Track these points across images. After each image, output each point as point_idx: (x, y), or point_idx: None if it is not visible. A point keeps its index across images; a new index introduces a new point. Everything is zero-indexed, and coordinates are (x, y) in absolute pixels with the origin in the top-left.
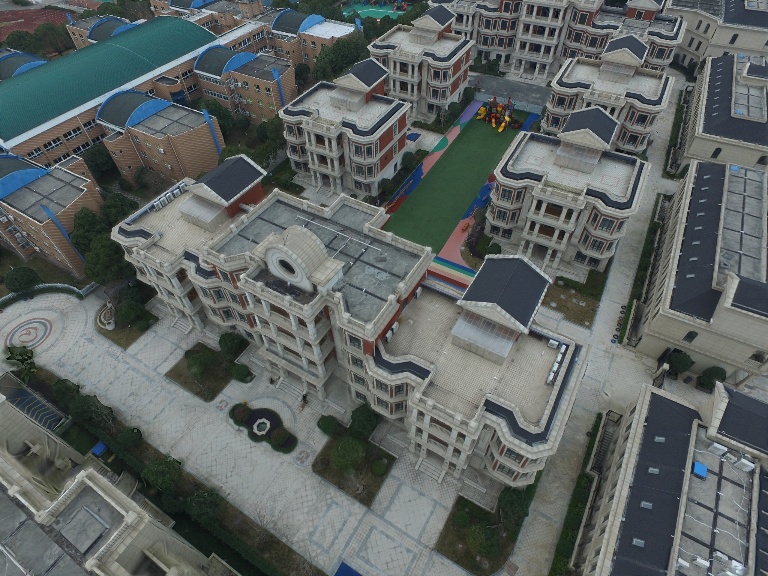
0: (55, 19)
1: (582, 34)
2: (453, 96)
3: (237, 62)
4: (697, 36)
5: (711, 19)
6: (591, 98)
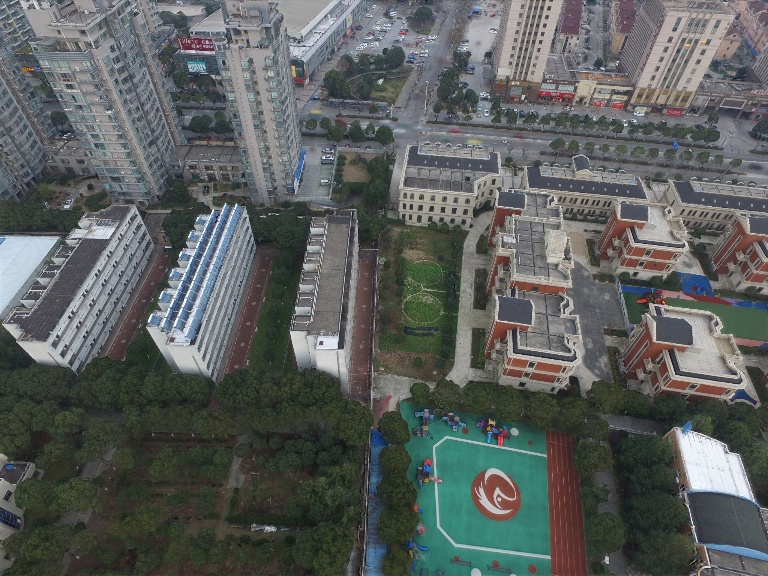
0: None
1: None
2: None
3: None
4: None
5: None
6: None
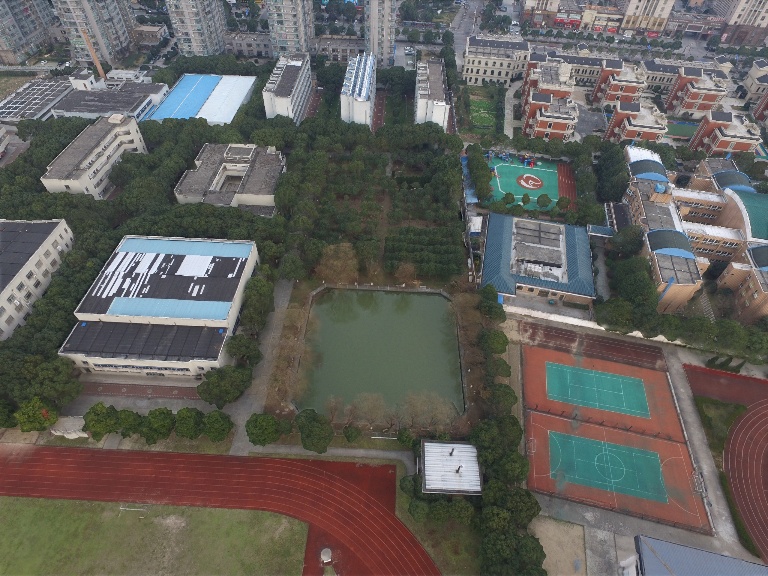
0: (760, 485)
1: None
2: None
3: None
4: None
5: None
6: None
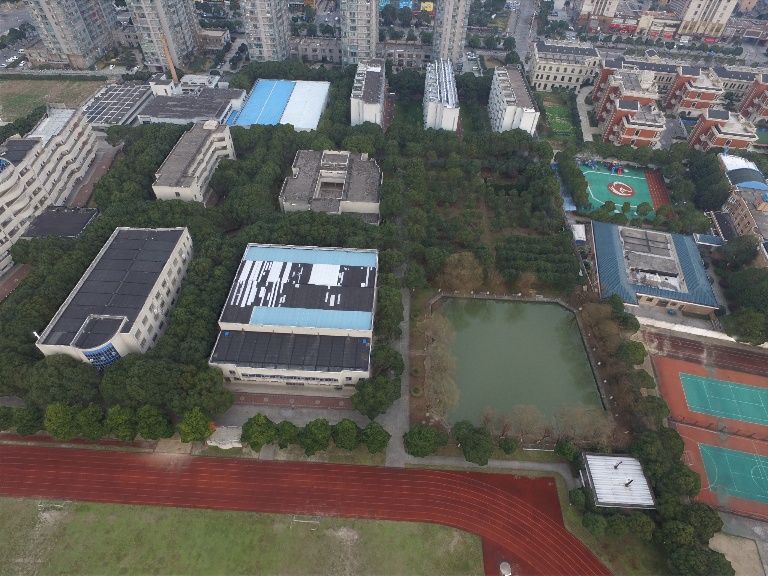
0: None
1: None
2: None
3: None
4: None
5: None
6: None
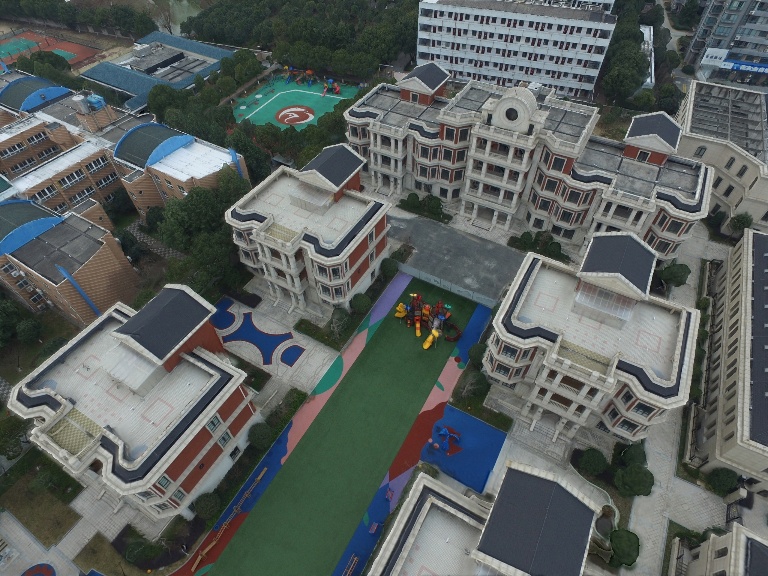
0: None
1: (557, 183)
2: (358, 286)
3: (21, 237)
4: (727, 177)
5: (749, 161)
6: (557, 368)
